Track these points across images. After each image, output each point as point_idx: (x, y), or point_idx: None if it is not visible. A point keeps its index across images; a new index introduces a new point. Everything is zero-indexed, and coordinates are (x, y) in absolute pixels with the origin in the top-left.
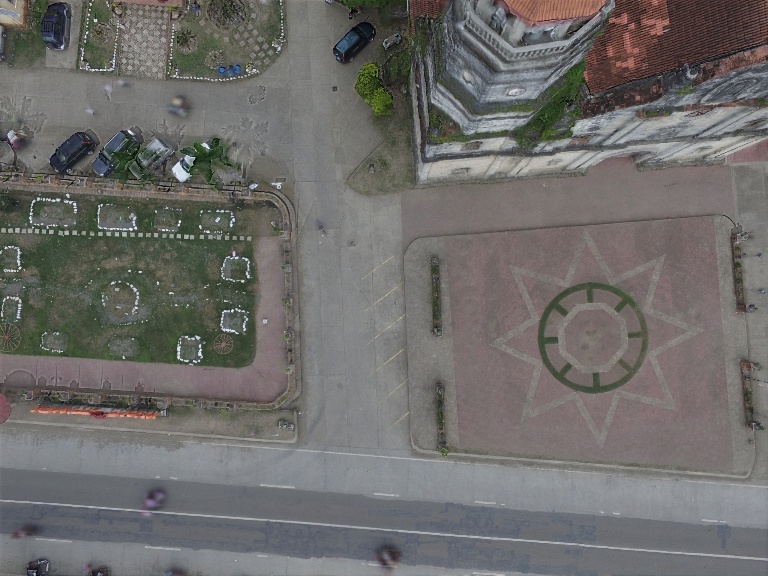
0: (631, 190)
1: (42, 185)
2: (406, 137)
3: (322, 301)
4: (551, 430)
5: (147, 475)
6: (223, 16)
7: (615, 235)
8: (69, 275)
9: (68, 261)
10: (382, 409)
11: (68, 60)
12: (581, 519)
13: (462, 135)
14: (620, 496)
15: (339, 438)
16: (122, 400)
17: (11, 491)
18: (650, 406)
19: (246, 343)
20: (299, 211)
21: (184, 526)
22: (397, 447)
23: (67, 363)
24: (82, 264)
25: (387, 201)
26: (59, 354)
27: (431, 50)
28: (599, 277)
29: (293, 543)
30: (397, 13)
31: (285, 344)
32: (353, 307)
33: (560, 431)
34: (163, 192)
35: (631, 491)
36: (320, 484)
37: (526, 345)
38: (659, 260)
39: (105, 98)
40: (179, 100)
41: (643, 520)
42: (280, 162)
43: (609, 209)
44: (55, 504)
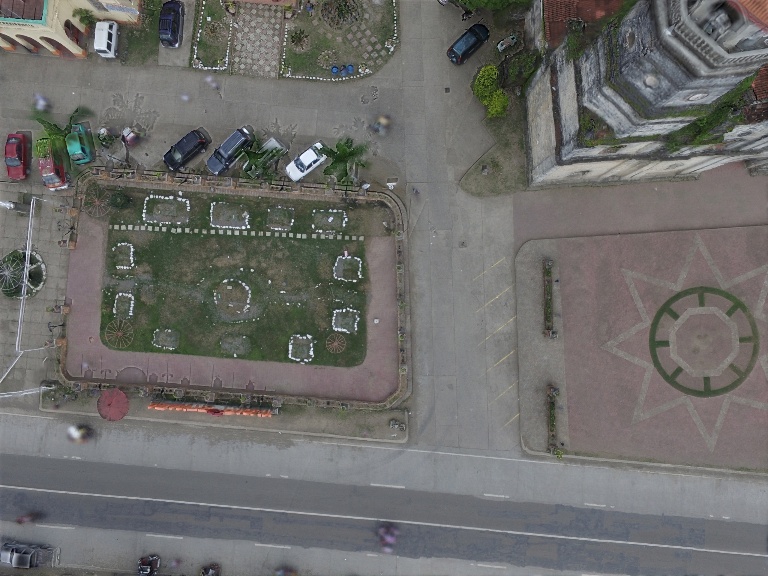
0: (743, 195)
1: (155, 182)
2: (519, 139)
3: (433, 302)
4: (661, 433)
5: (258, 473)
6: (338, 16)
7: (727, 240)
8: (181, 272)
9: (180, 258)
10: (492, 410)
11: (181, 58)
12: (690, 523)
13: (614, 139)
14: (729, 500)
15: (449, 439)
16: (234, 398)
17: (122, 487)
18: (761, 411)
19: (357, 343)
20: (411, 212)
21: (294, 524)
22: (507, 448)
23: (178, 360)
24: (194, 262)
25: (499, 203)
26: (170, 351)
27: (595, 54)
28: (711, 281)
29: (403, 543)
30: (515, 15)
31: (396, 344)
32: (464, 308)
33: (670, 434)
34: (276, 191)
35: (741, 495)
36: (430, 484)
37: (637, 348)
38: None
39: (217, 96)
40: (291, 99)
41: (752, 524)
42: (392, 162)
43: (721, 214)
44: (166, 501)
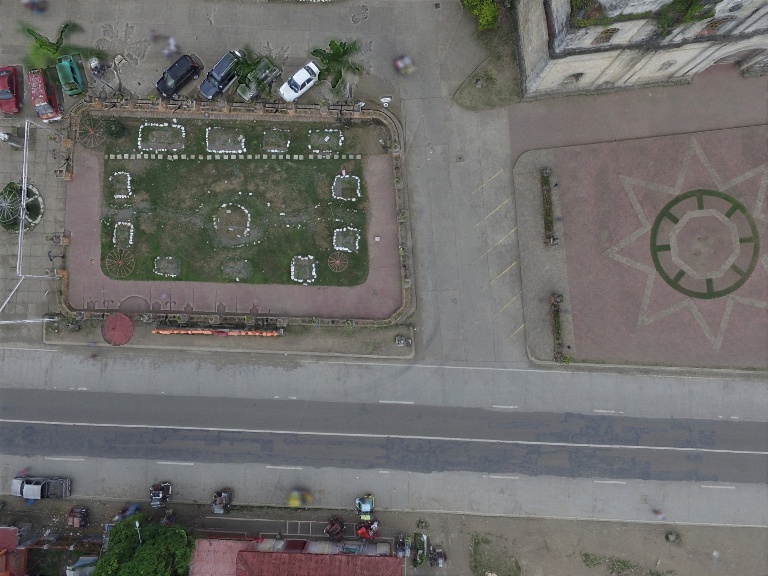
0: (736, 97)
1: (149, 111)
2: (511, 51)
3: (433, 217)
4: (667, 337)
5: (266, 395)
6: None
7: (723, 141)
8: (179, 199)
9: (178, 185)
10: (497, 322)
11: None
12: (699, 424)
13: (606, 17)
14: (737, 400)
15: (455, 352)
16: (238, 321)
17: (130, 416)
18: (764, 310)
19: (359, 261)
20: (406, 128)
21: (305, 445)
22: (514, 359)
23: (181, 287)
24: (192, 188)
25: (494, 115)
26: (172, 278)
27: None
28: (708, 184)
29: (414, 458)
30: None
31: (398, 261)
32: (464, 222)
33: (676, 337)
34: (271, 113)
35: (748, 395)
36: (439, 398)
37: (638, 253)
38: (767, 165)
39: (208, 22)
40: (282, 22)
41: (761, 423)
42: (385, 81)
43: (715, 116)
44: (175, 427)
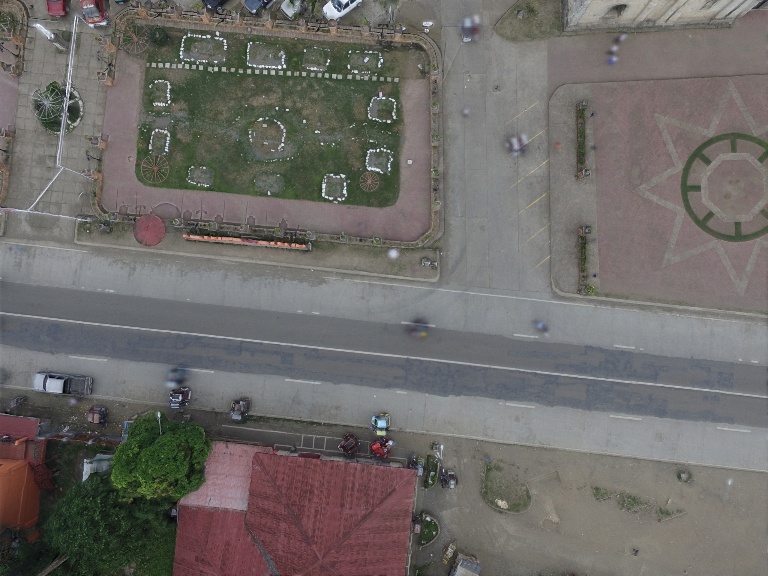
0: None
1: (193, 22)
2: None
3: (466, 144)
4: (692, 277)
5: (289, 309)
6: None
7: (760, 87)
8: (217, 111)
9: (216, 97)
10: (523, 252)
11: None
12: (719, 366)
13: None
14: (759, 345)
15: (480, 279)
16: (268, 233)
17: (155, 320)
18: None
19: (390, 183)
20: (445, 55)
21: (325, 360)
22: (537, 290)
23: (212, 197)
24: (230, 101)
25: (533, 48)
26: (205, 188)
27: None
28: (743, 128)
29: (432, 381)
30: None
31: (428, 185)
32: (497, 151)
33: (701, 278)
34: (312, 32)
35: None
36: (460, 323)
37: (669, 193)
38: None
39: None
40: None
41: None
42: (427, 7)
43: (754, 62)
44: (198, 334)
